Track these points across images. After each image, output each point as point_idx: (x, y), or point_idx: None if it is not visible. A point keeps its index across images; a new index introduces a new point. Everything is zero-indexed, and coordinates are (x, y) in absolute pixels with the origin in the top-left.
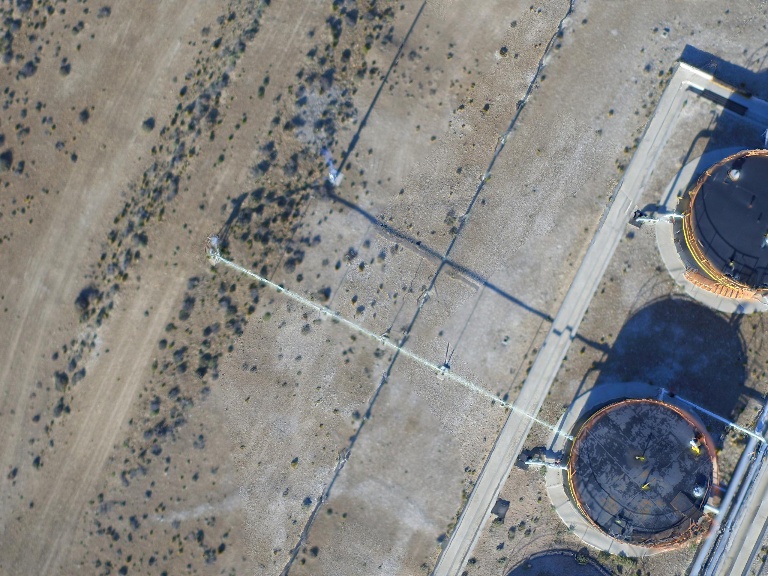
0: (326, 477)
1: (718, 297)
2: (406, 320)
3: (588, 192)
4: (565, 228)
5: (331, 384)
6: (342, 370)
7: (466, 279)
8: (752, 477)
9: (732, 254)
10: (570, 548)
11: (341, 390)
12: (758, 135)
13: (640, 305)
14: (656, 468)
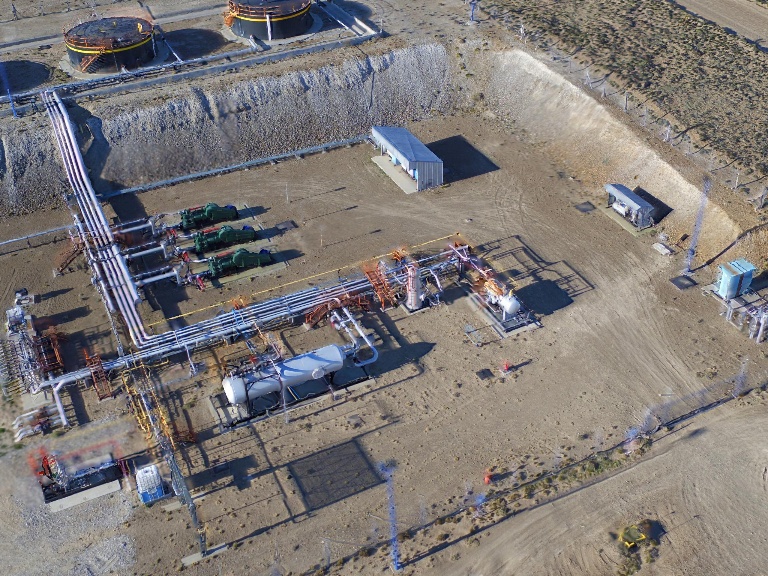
0: (2, 21)
1: (232, 35)
2: (102, 3)
3: (226, 2)
4: (202, 6)
5: (48, 6)
6: (58, 5)
7: (142, 4)
8: (157, 67)
9: (245, 3)
10: (51, 65)
11: (48, 8)
12: (320, 11)
13: (197, 28)
14: (116, 30)
